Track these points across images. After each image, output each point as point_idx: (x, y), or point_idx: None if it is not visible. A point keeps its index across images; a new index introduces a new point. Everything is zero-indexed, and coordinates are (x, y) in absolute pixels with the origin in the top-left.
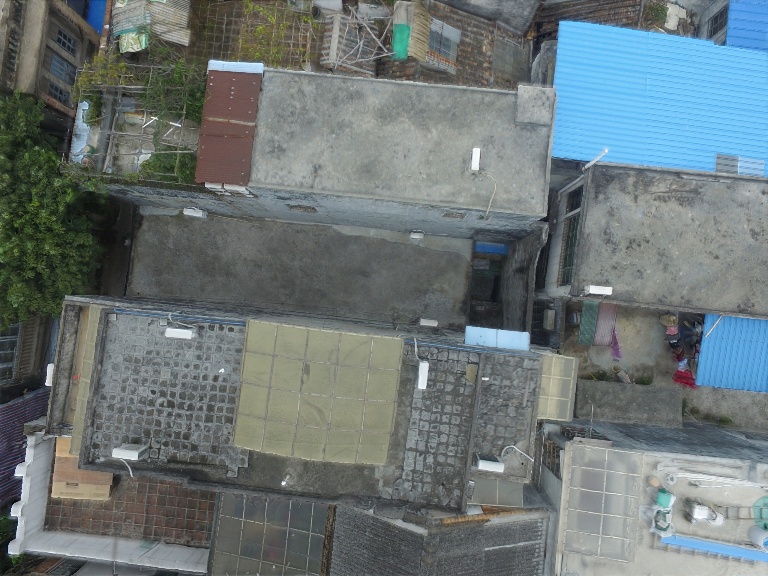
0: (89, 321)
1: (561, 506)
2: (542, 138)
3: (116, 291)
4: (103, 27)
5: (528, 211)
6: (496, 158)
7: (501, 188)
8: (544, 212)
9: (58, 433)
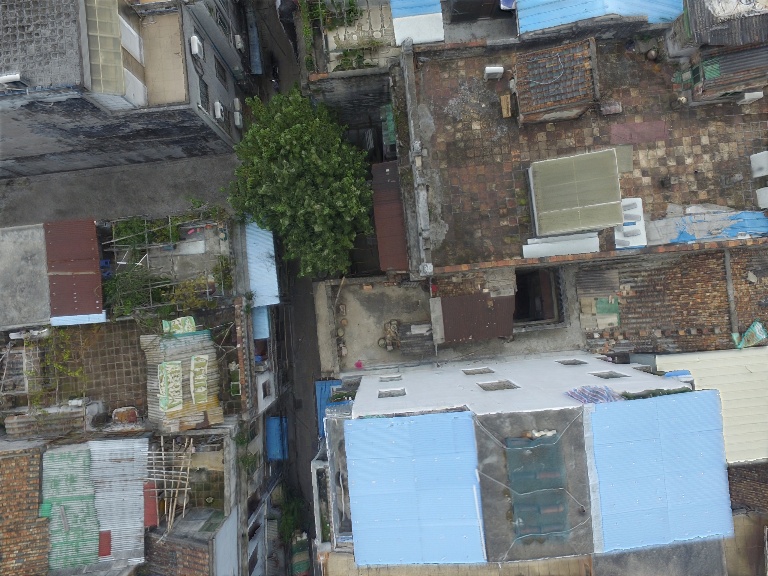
0: (123, 82)
1: None
2: None
3: None
4: (241, 345)
5: None
6: None
7: None
8: None
9: (173, 1)
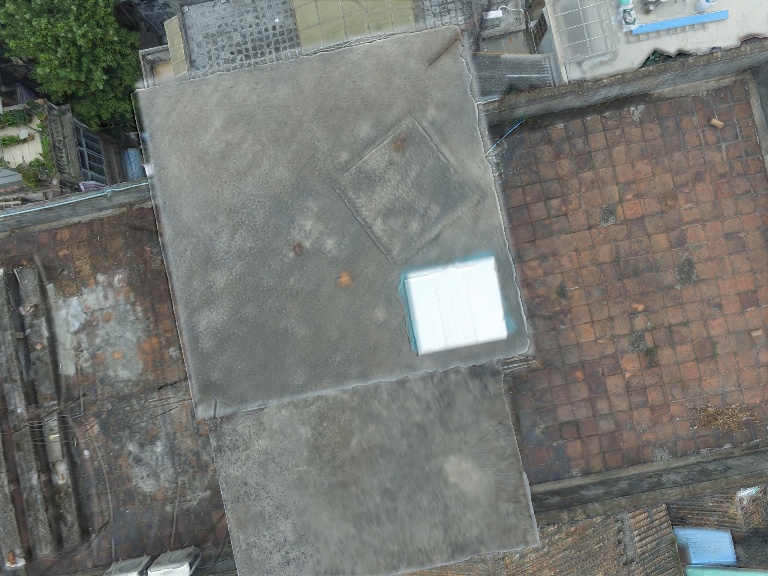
0: None
1: (553, 33)
2: None
3: None
4: None
5: None
6: None
7: None
8: None
9: None
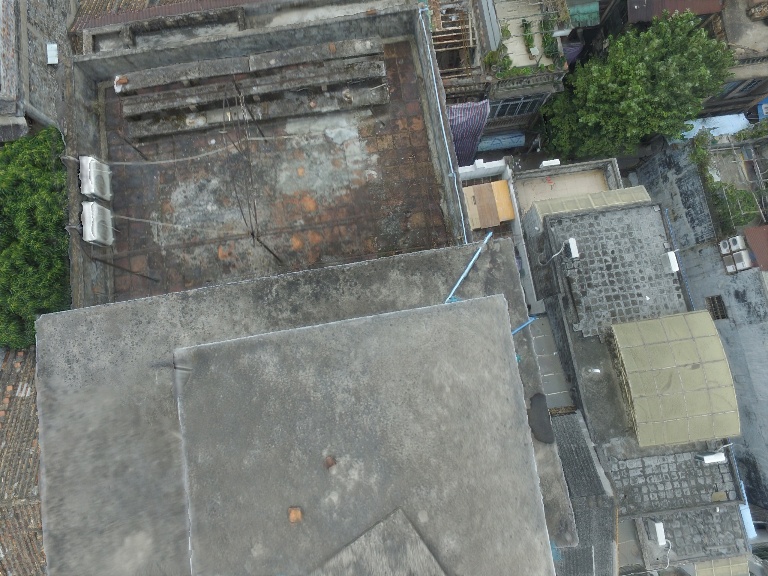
0: (631, 188)
1: None
2: None
3: (529, 164)
4: None
5: None
6: None
7: None
8: None
9: (514, 181)
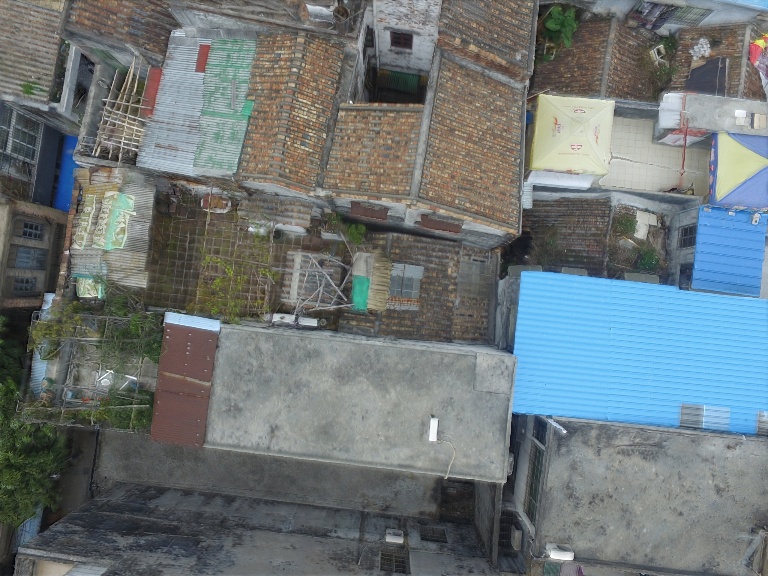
0: None
1: None
2: (502, 400)
3: (88, 446)
4: None
5: (487, 476)
6: (455, 420)
7: (460, 451)
8: (504, 478)
9: None
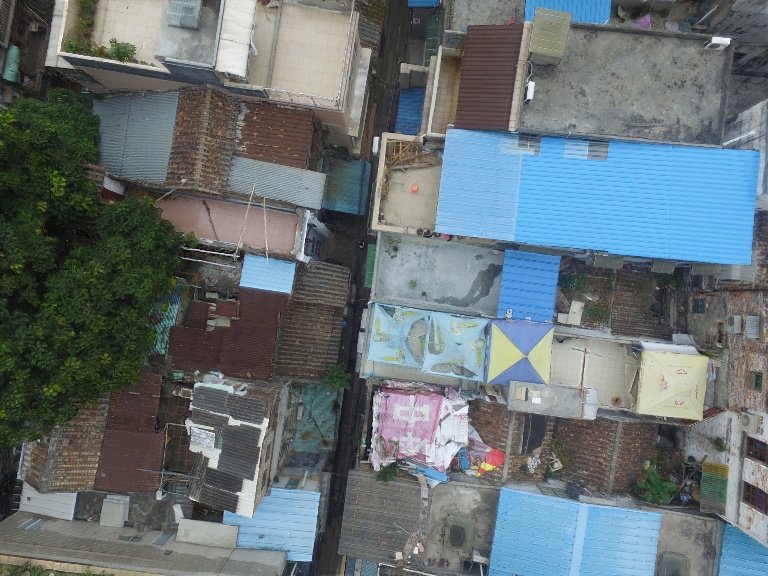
0: None
1: None
2: None
3: None
4: None
5: None
6: None
7: None
8: None
9: None
